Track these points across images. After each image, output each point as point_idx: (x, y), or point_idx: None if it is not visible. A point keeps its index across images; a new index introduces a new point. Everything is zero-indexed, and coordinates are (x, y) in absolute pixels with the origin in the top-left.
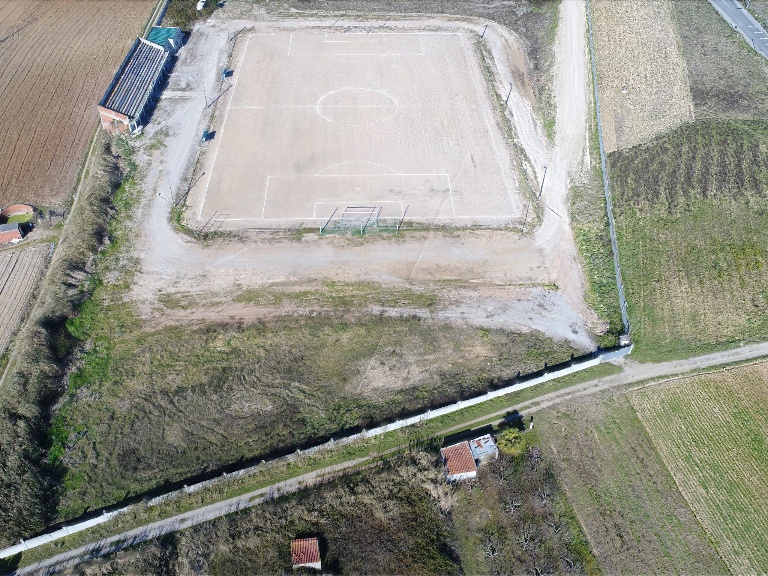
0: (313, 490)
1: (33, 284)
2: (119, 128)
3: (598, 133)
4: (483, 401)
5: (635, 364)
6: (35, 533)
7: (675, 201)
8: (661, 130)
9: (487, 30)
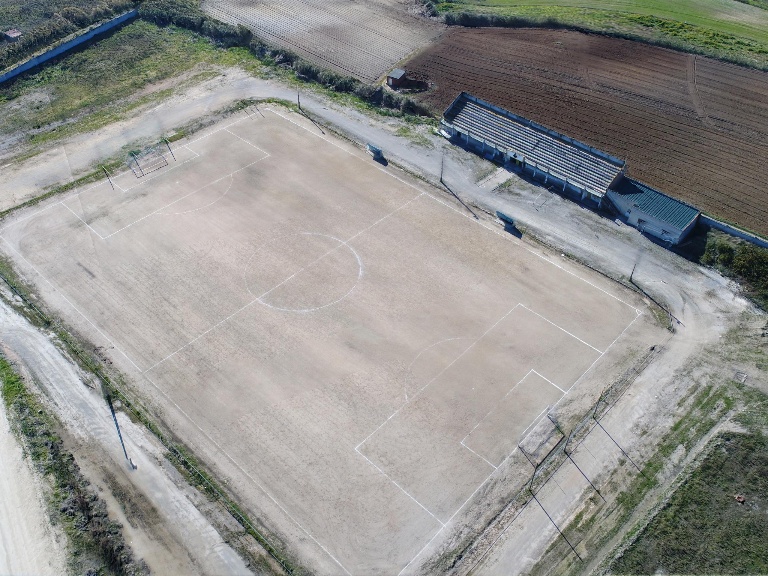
0: None
1: None
2: None
3: None
4: None
5: None
6: None
7: None
8: None
9: None
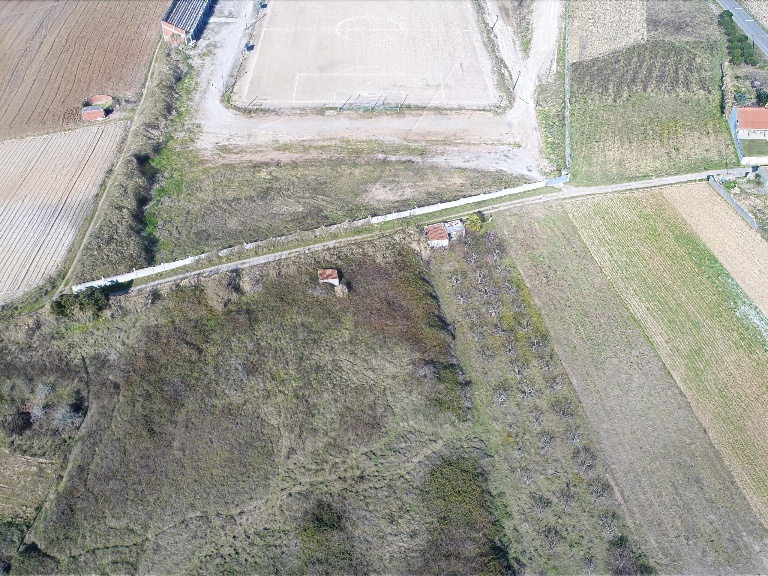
0: (333, 248)
1: (117, 145)
2: (177, 41)
3: (565, 49)
4: (457, 206)
5: (571, 187)
6: (142, 267)
7: (620, 94)
8: (617, 48)
9: None
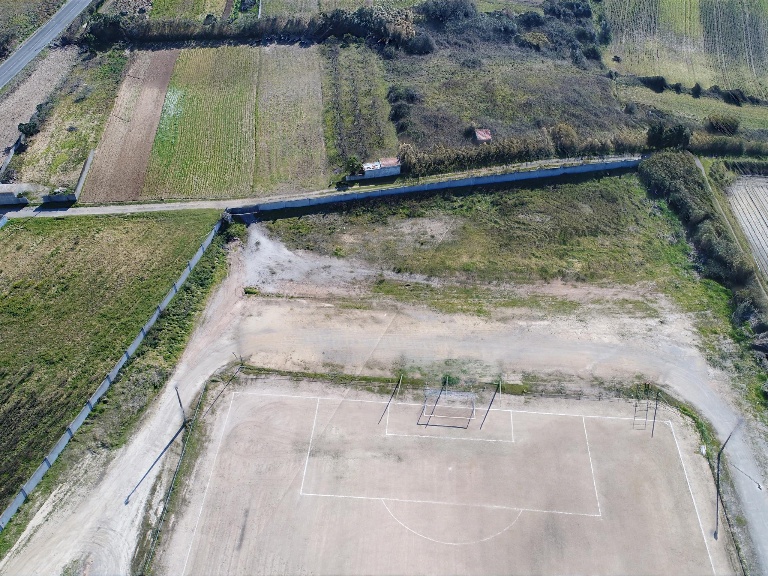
0: None
1: None
2: None
3: None
4: None
5: None
6: None
7: (1, 394)
8: None
9: None
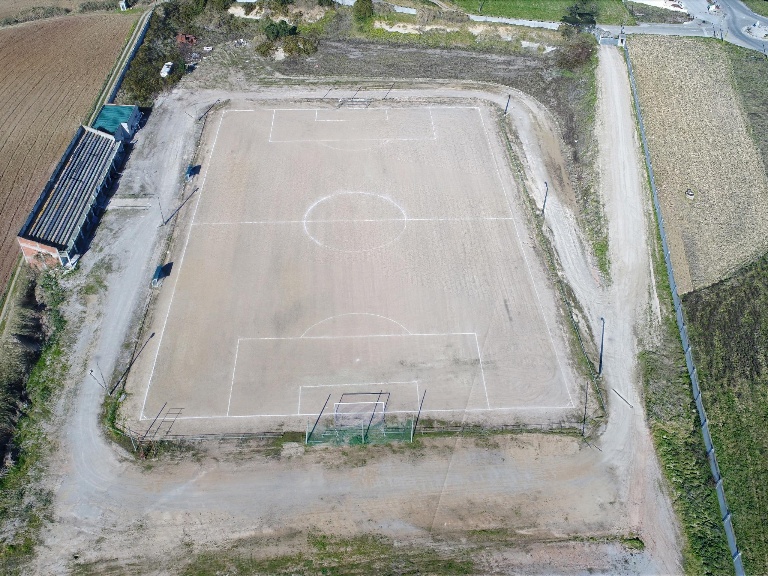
0: None
1: None
2: (47, 261)
3: (665, 263)
4: None
5: None
6: None
7: None
8: (745, 257)
9: (510, 102)
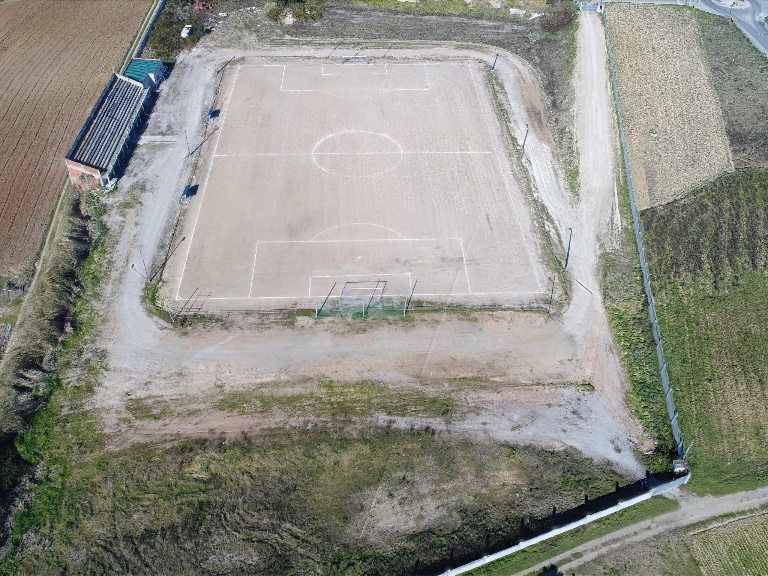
0: None
1: None
2: (89, 182)
3: (628, 186)
4: (513, 552)
5: (693, 497)
6: None
7: (721, 273)
8: (698, 182)
9: (498, 60)
